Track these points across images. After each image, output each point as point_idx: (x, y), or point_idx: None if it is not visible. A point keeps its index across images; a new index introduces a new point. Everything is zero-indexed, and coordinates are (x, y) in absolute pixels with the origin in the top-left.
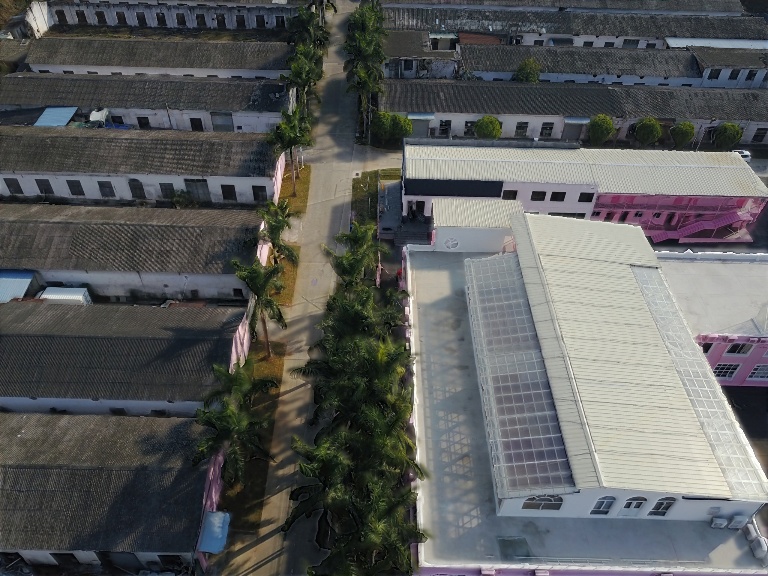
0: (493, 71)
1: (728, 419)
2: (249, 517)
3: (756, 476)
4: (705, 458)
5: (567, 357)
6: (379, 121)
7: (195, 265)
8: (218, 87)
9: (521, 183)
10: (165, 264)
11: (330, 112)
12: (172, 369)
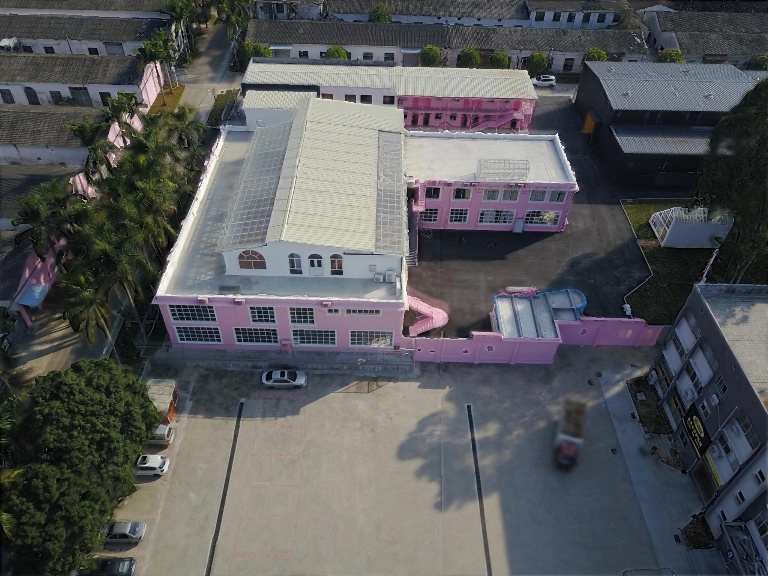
0: (352, 14)
1: (401, 215)
2: (70, 299)
3: (402, 243)
4: (368, 232)
5: (295, 177)
6: (243, 49)
7: (59, 140)
8: (112, 22)
9: (334, 87)
10: (36, 139)
11: (213, 48)
12: (21, 198)
